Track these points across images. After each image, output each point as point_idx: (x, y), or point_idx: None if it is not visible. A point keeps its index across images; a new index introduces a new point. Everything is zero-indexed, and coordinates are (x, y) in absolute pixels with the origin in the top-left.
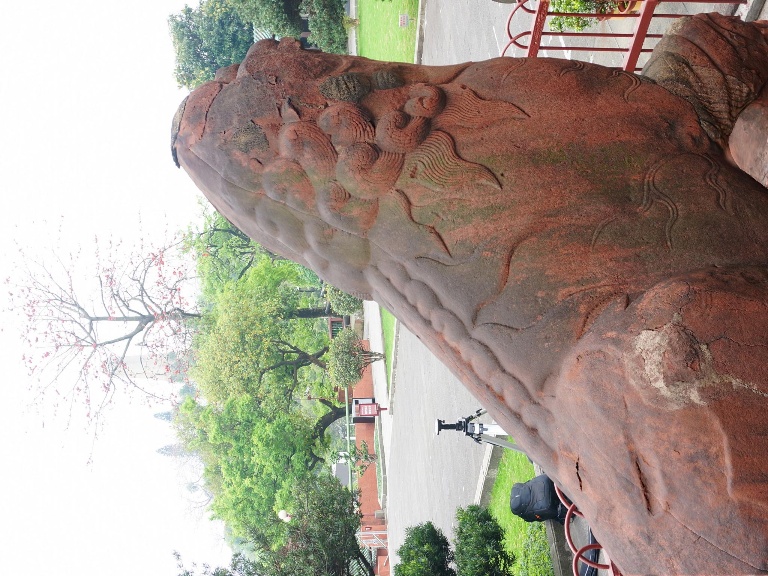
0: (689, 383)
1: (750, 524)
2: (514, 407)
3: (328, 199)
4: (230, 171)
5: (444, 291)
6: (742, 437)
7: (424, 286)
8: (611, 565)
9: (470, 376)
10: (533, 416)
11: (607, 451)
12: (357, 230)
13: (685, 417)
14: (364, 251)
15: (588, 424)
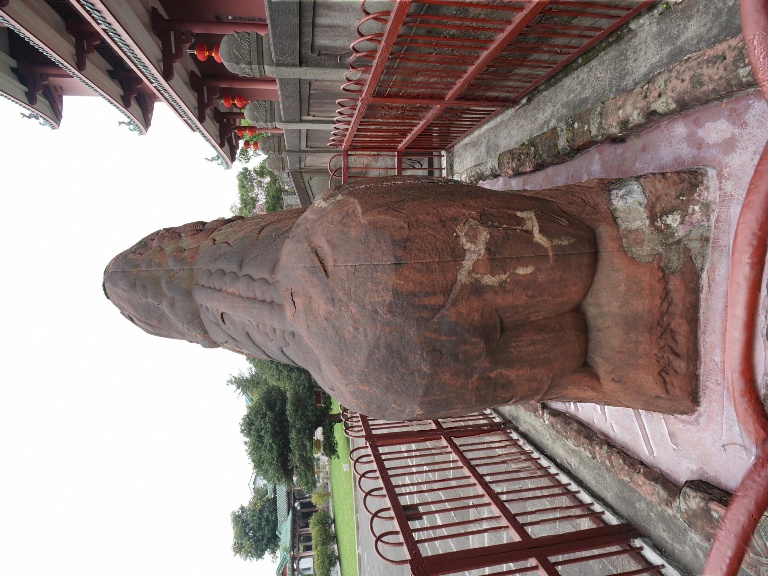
0: (336, 195)
1: (378, 231)
2: (261, 297)
3: (172, 253)
4: (125, 265)
5: (226, 263)
6: (366, 197)
7: (218, 270)
8: (404, 540)
9: (239, 300)
10: (270, 291)
11: (301, 261)
12: (187, 264)
13: (335, 207)
14: (190, 275)
15: (291, 258)
